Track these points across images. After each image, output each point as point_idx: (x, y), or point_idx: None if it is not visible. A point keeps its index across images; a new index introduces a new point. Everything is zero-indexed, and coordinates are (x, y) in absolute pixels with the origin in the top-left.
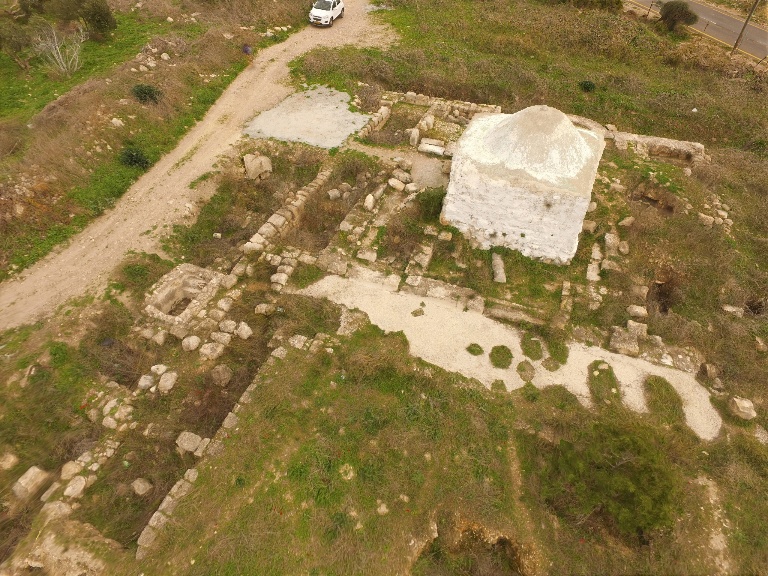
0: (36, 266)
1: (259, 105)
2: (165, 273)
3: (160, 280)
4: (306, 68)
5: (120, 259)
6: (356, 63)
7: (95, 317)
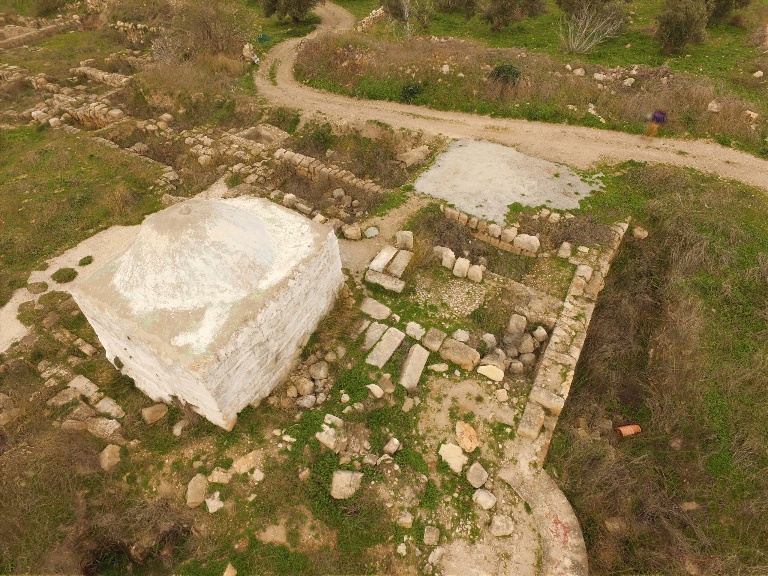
0: (309, 88)
1: (533, 146)
2: (280, 128)
3: (273, 126)
4: (644, 170)
5: (295, 107)
6: (679, 212)
7: (251, 110)
